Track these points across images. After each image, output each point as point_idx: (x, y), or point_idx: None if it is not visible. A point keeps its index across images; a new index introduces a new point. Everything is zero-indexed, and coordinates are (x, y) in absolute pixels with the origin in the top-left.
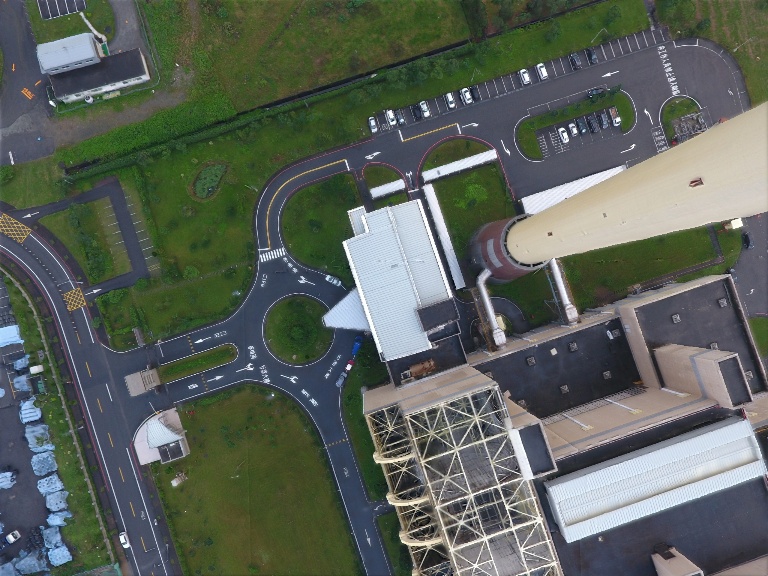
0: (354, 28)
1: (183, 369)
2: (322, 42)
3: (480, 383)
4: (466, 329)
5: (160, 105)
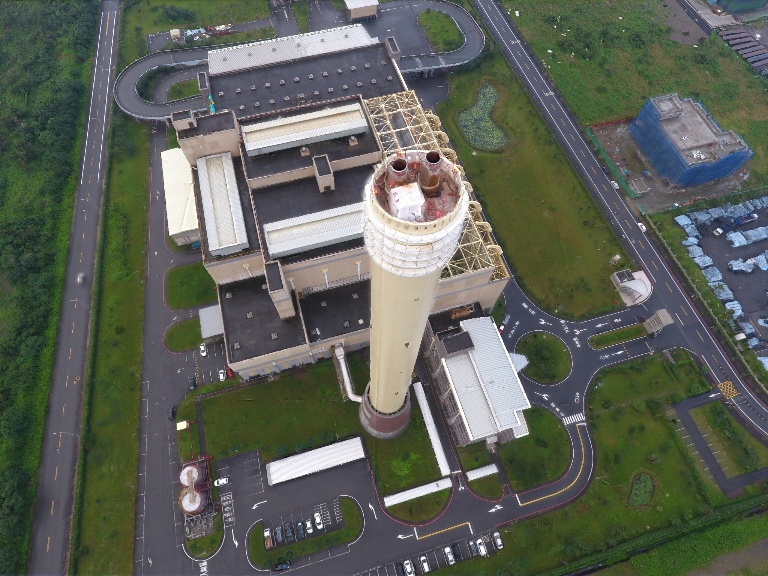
0: None
1: (628, 332)
2: None
3: None
4: None
5: (706, 573)
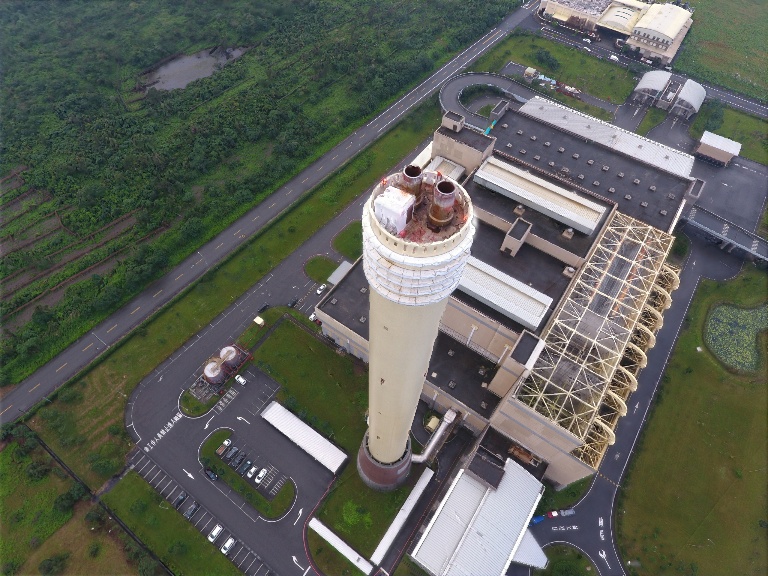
0: None
1: None
2: None
3: (516, 408)
4: (454, 444)
5: None
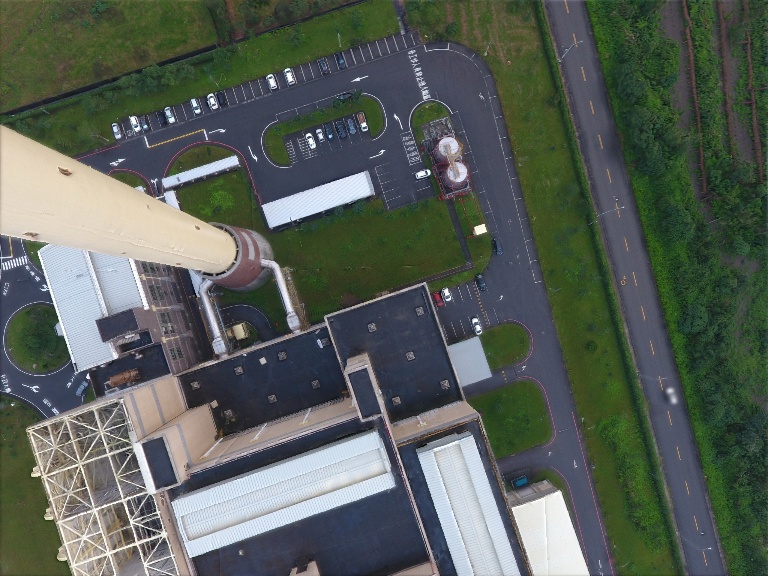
0: (98, 33)
1: None
2: (66, 48)
3: None
4: None
5: None
